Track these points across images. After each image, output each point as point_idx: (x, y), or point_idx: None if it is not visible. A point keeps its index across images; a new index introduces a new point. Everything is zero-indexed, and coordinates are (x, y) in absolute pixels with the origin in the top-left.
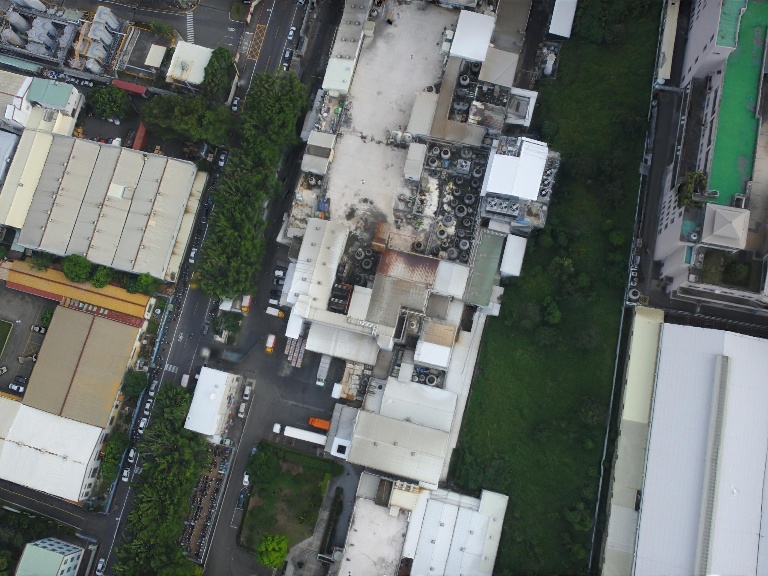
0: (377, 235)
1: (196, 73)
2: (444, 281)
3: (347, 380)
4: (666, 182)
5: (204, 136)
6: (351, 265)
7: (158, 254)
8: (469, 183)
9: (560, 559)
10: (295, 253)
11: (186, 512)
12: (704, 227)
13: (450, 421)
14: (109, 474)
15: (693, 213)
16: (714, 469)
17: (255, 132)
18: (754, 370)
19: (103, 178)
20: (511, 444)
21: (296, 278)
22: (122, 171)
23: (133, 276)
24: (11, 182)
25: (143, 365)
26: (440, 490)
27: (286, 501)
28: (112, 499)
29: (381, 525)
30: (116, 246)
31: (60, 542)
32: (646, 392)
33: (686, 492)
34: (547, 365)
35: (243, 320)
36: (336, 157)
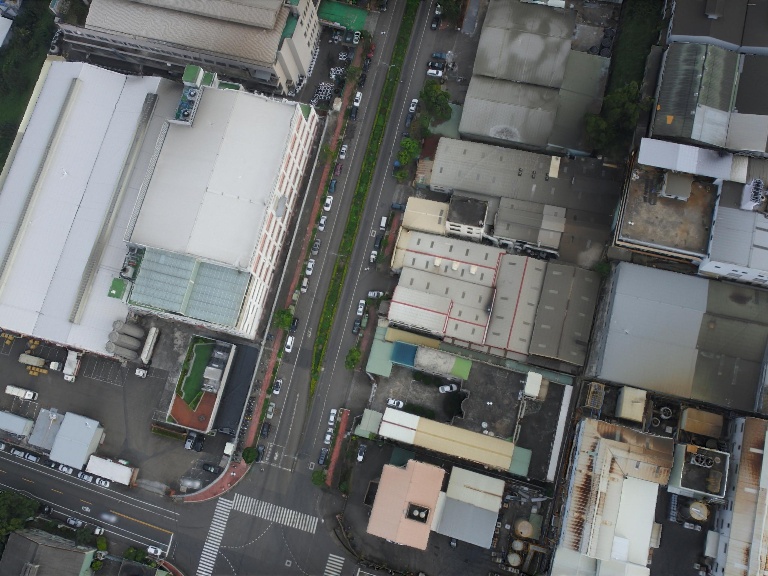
0: None
1: None
2: None
3: None
4: None
5: None
6: None
7: None
8: None
9: None
10: None
11: None
12: None
13: None
14: None
15: None
16: (46, 153)
17: None
18: (102, 93)
19: None
20: None
21: None
22: None
23: None
24: None
25: None
26: None
27: None
28: None
29: None
30: None
31: None
32: None
33: (30, 173)
34: (1, 108)
35: None
36: None
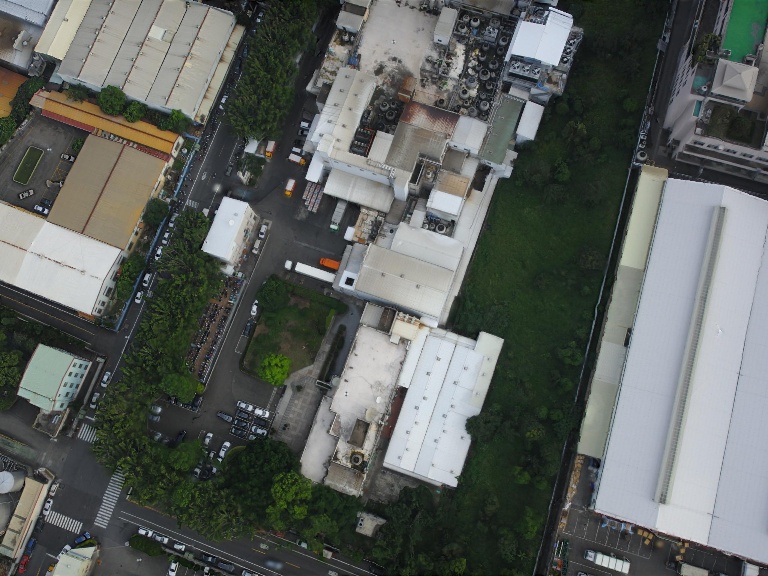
0: (403, 87)
1: None
2: (463, 134)
3: (360, 225)
4: (681, 58)
5: None
6: (375, 116)
7: (191, 94)
8: (494, 51)
9: (548, 394)
10: (323, 98)
11: (194, 334)
12: (715, 79)
13: (455, 266)
14: (124, 291)
15: (705, 70)
16: (702, 306)
17: None
18: (748, 225)
19: (145, 20)
20: (511, 292)
21: (322, 120)
22: (164, 15)
23: (165, 114)
24: (57, 17)
25: None
26: (439, 329)
27: (291, 331)
28: (123, 318)
29: (381, 352)
30: (151, 84)
31: (69, 353)
32: (645, 241)
33: (674, 328)
34: (552, 221)
35: (265, 165)
36: (370, 17)
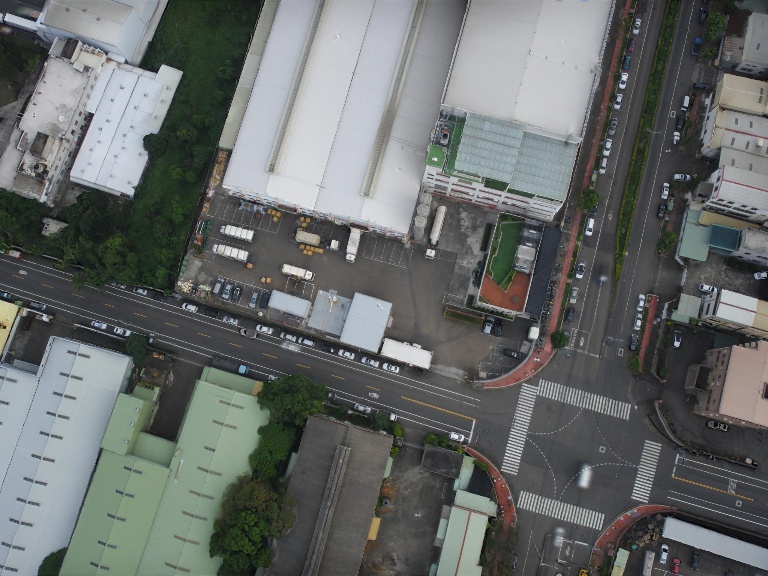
0: None
1: None
2: None
3: None
4: None
5: None
6: None
7: None
8: None
9: (210, 110)
10: None
11: None
12: None
13: (143, 10)
14: None
15: None
16: (320, 12)
17: None
18: None
19: None
20: (191, 31)
21: None
22: None
23: None
24: None
25: None
26: (127, 65)
27: None
28: None
29: (67, 79)
30: None
31: None
32: None
33: (299, 34)
34: None
35: None
36: None
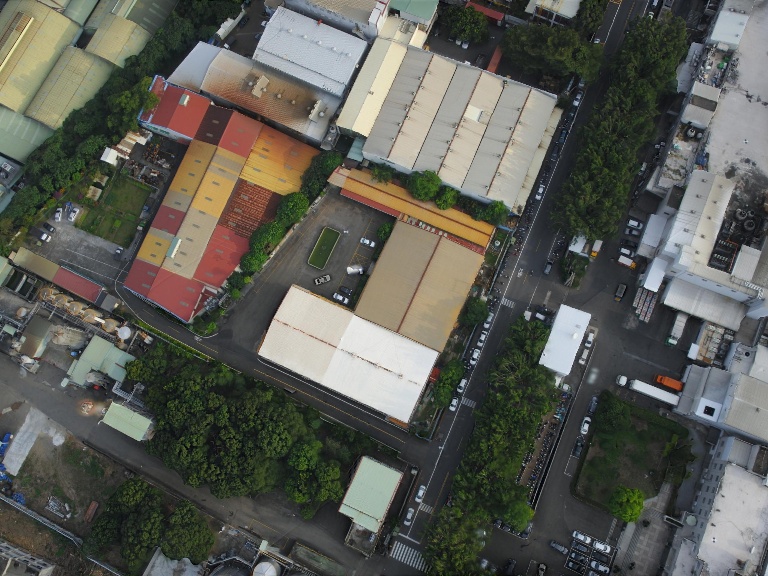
0: None
1: (568, 6)
2: None
3: (705, 342)
4: None
5: (580, 70)
6: None
7: (513, 184)
8: None
9: None
10: (674, 203)
11: None
12: None
13: None
14: (445, 400)
15: None
16: None
17: (634, 74)
18: None
19: (460, 98)
20: None
21: (677, 228)
22: (481, 94)
23: (479, 203)
24: (360, 88)
25: (476, 295)
26: None
27: (630, 456)
28: (436, 426)
29: (751, 495)
30: (468, 169)
31: None
32: None
33: None
34: None
35: (588, 265)
36: (718, 112)
